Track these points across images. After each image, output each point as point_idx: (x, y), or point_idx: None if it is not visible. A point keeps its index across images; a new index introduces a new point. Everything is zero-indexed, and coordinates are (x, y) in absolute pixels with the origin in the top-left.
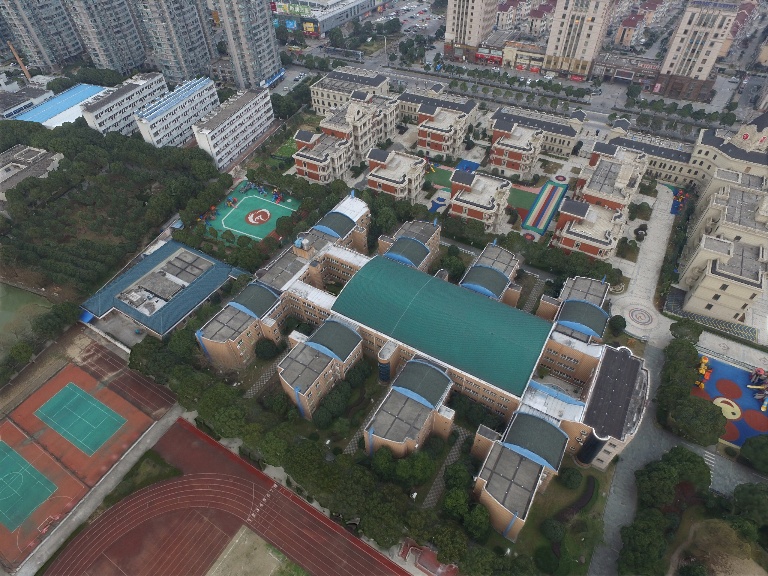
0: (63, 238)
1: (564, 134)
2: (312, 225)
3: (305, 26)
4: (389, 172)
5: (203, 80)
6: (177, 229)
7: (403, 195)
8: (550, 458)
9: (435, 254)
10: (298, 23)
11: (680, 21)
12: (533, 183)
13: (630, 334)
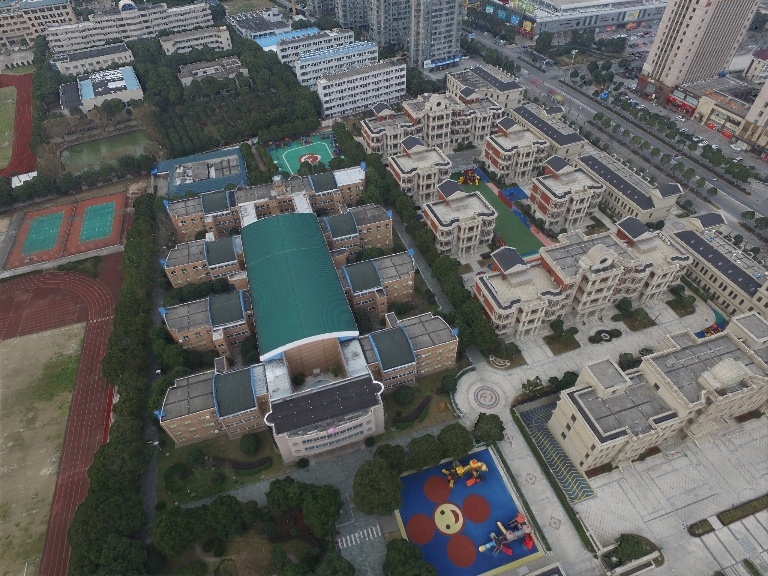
0: (201, 123)
1: (636, 202)
2: None
3: (525, 24)
4: (409, 161)
5: (371, 44)
6: (255, 144)
7: (405, 185)
8: (224, 405)
9: (386, 245)
10: (520, 20)
11: None
12: (555, 236)
13: (452, 401)
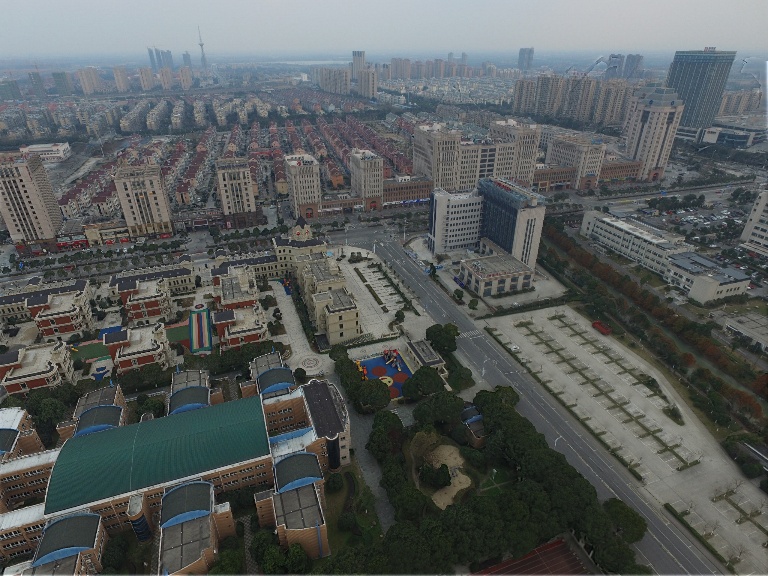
0: None
1: (182, 275)
2: None
3: None
4: (28, 368)
5: None
6: None
7: (58, 381)
8: (314, 474)
9: (126, 412)
10: None
11: (217, 180)
12: (179, 319)
13: (311, 376)
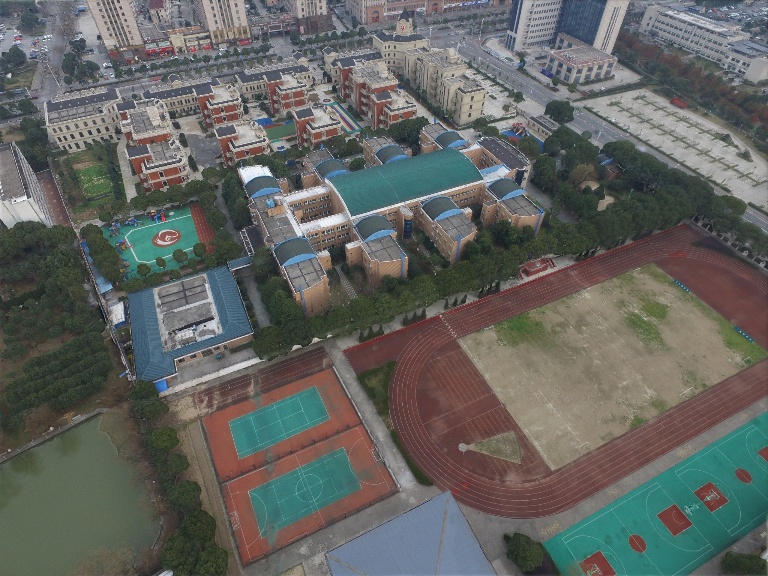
0: None
1: (302, 72)
2: None
3: None
4: (244, 140)
5: None
6: (108, 292)
7: (269, 150)
8: None
9: None
10: None
11: None
12: None
13: None
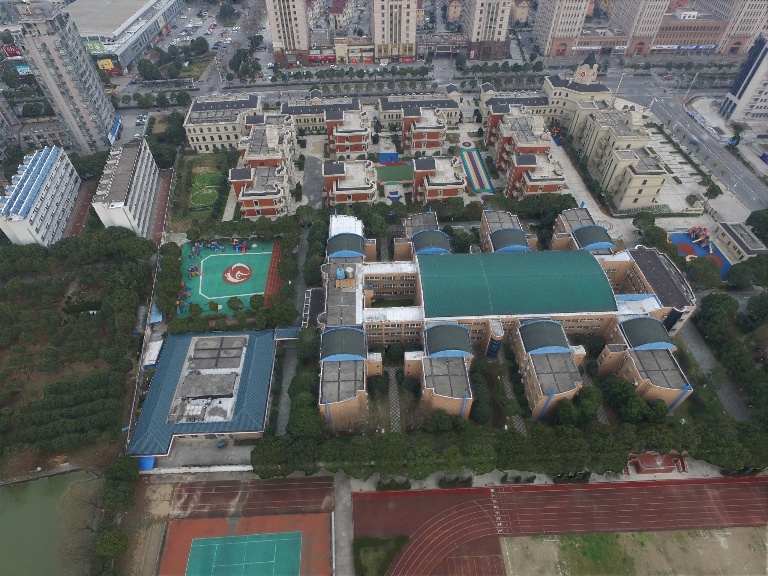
0: None
1: (450, 107)
2: (321, 256)
3: (100, 64)
4: (351, 182)
5: (48, 150)
6: (157, 323)
7: None
8: (668, 341)
9: None
10: None
11: None
12: None
13: None
